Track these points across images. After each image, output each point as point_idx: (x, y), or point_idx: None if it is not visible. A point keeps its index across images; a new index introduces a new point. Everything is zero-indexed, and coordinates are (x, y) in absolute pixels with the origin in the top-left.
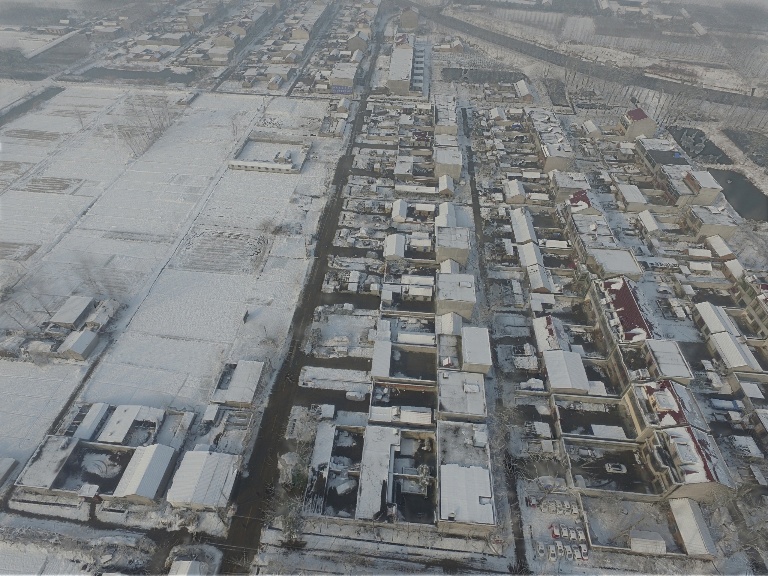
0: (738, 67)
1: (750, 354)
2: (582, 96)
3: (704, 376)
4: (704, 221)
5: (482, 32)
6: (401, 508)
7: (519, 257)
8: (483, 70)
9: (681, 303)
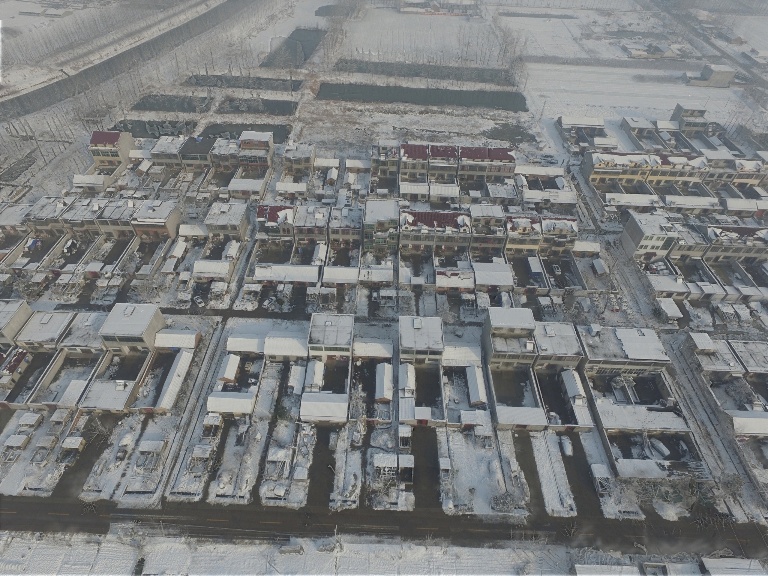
0: (6, 61)
1: (444, 185)
2: None
3: (466, 210)
4: (307, 156)
5: None
6: (650, 403)
7: (343, 283)
8: None
9: None
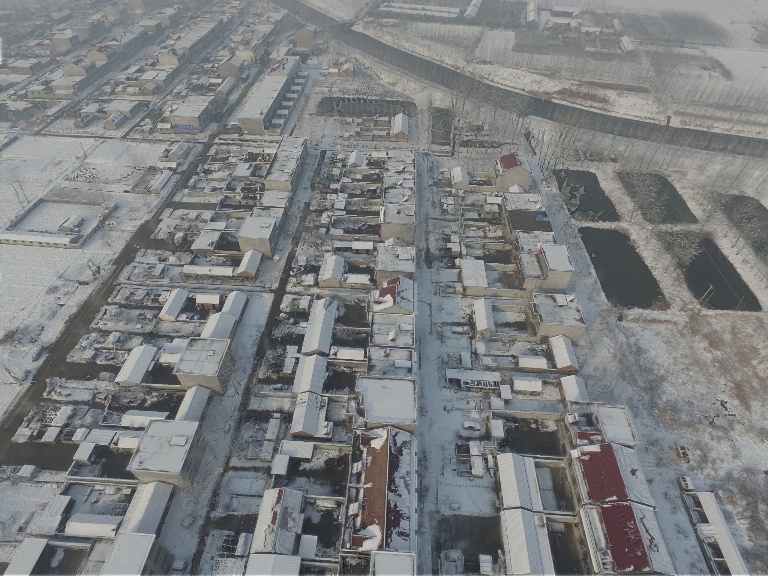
0: (658, 90)
1: (546, 546)
2: (468, 131)
3: None
4: (543, 319)
5: (381, 52)
6: None
7: None
8: (356, 102)
9: (483, 450)
